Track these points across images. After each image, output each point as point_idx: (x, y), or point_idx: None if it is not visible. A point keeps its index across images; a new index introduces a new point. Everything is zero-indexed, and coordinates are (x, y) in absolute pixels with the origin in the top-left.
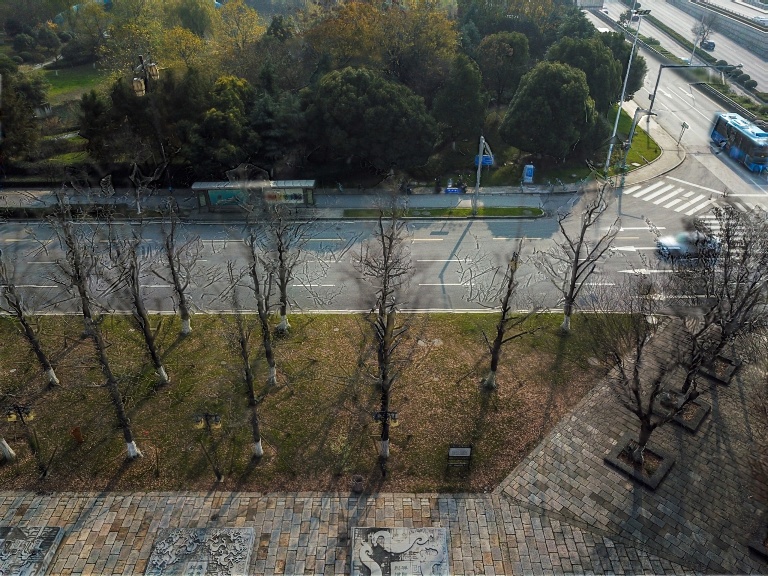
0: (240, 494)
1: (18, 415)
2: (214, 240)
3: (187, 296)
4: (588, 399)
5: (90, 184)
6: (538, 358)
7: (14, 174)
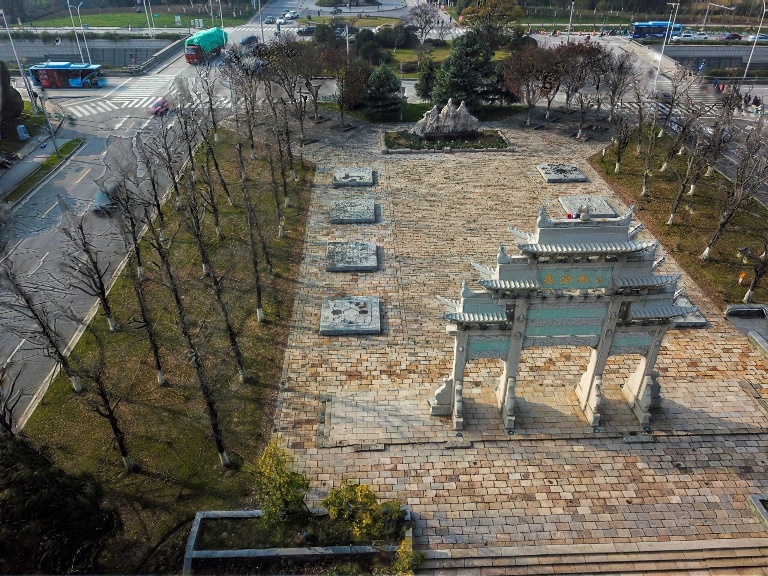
0: None
1: None
2: (8, 254)
3: None
4: None
5: None
6: None
7: None
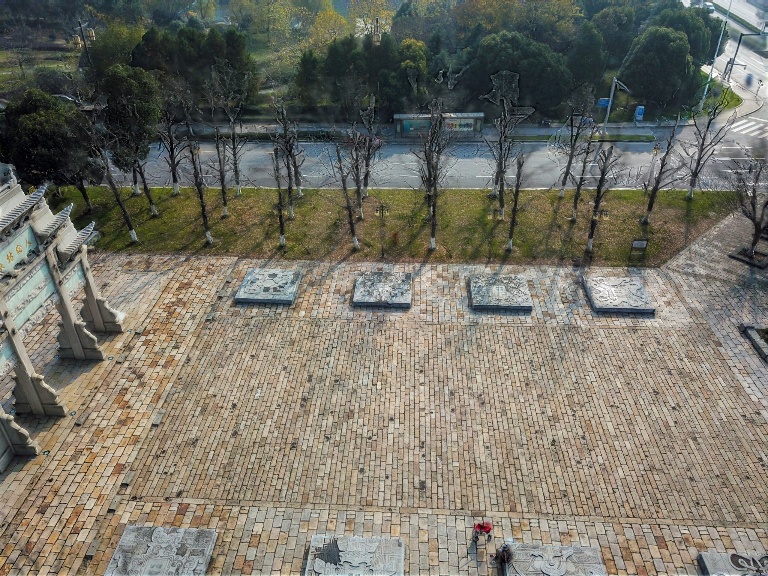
0: (505, 265)
1: (381, 212)
2: None
3: None
4: (712, 231)
5: (305, 120)
6: (674, 211)
7: (246, 114)
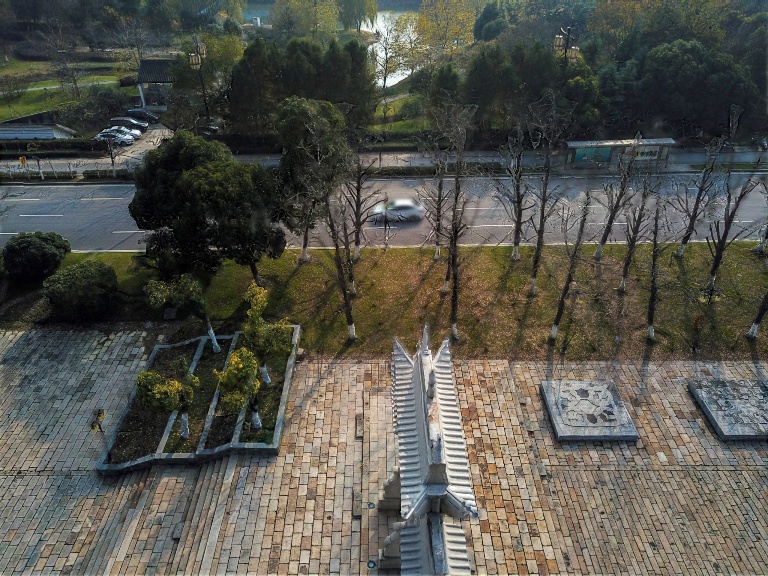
0: None
1: (708, 297)
2: None
3: None
4: None
5: (443, 148)
6: None
7: None
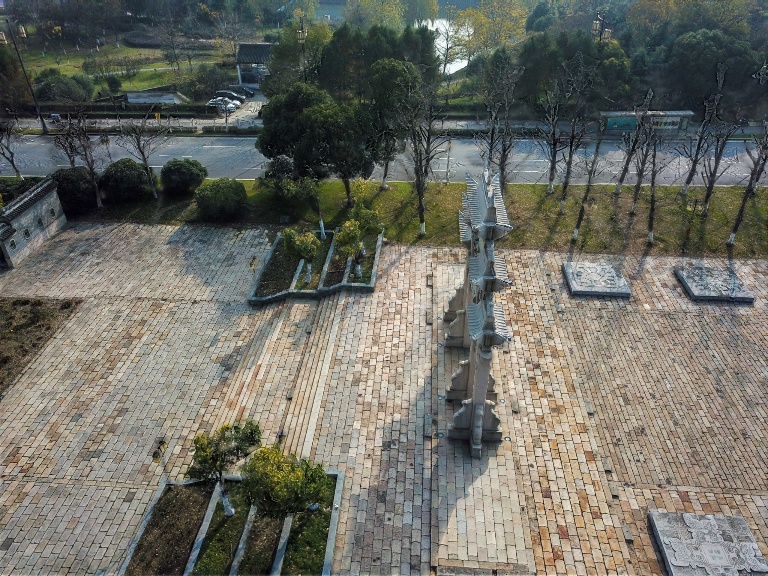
0: None
1: (694, 206)
2: None
3: (697, 166)
4: None
5: None
6: None
7: None
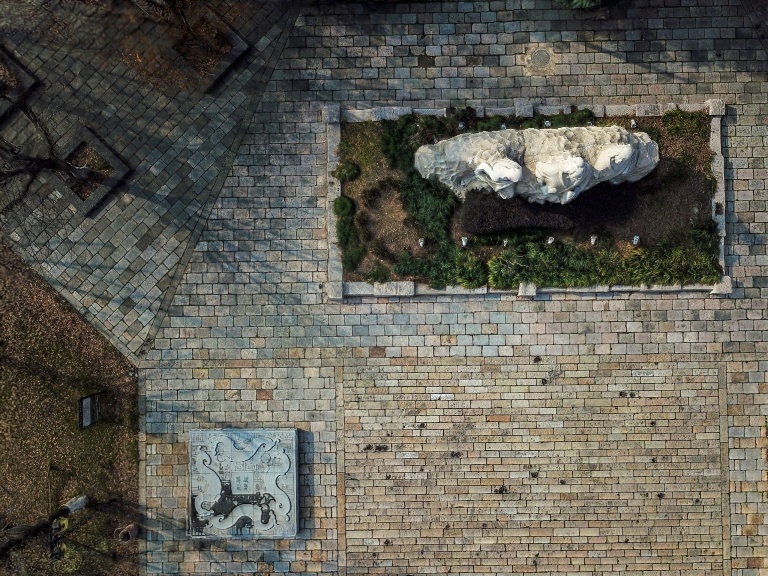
0: None
1: None
2: None
3: None
4: None
5: None
6: None
7: None
